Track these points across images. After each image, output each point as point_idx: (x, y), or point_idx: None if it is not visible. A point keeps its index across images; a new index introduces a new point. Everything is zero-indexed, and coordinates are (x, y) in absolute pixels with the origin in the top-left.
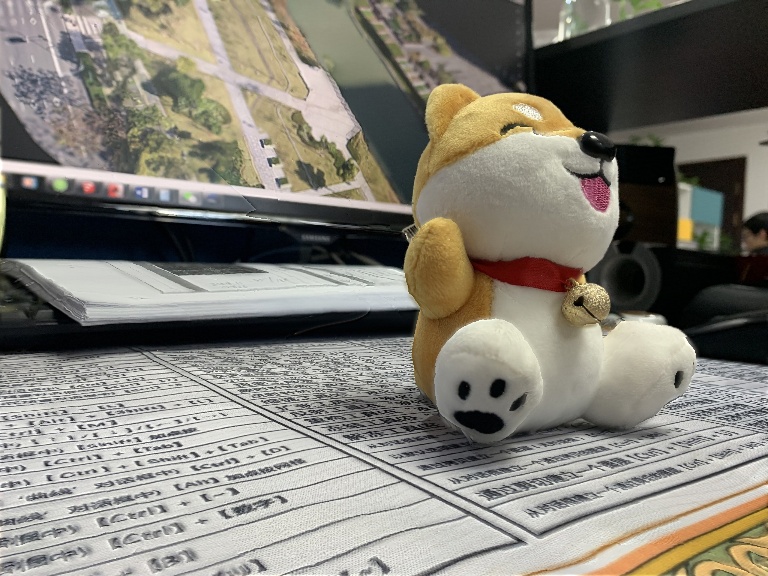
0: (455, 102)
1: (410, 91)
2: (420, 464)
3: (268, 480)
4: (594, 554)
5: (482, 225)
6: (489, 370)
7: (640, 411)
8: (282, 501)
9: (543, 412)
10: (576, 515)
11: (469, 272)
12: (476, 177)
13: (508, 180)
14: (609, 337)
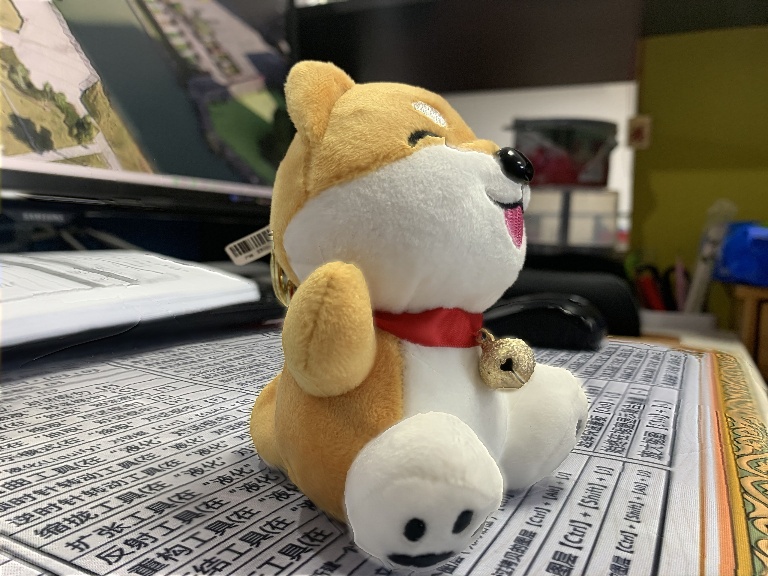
0: (331, 89)
1: (160, 37)
2: None
3: None
4: None
5: (391, 270)
6: (455, 502)
7: (544, 471)
8: None
9: None
10: None
11: (373, 334)
12: (386, 206)
13: (430, 213)
14: None
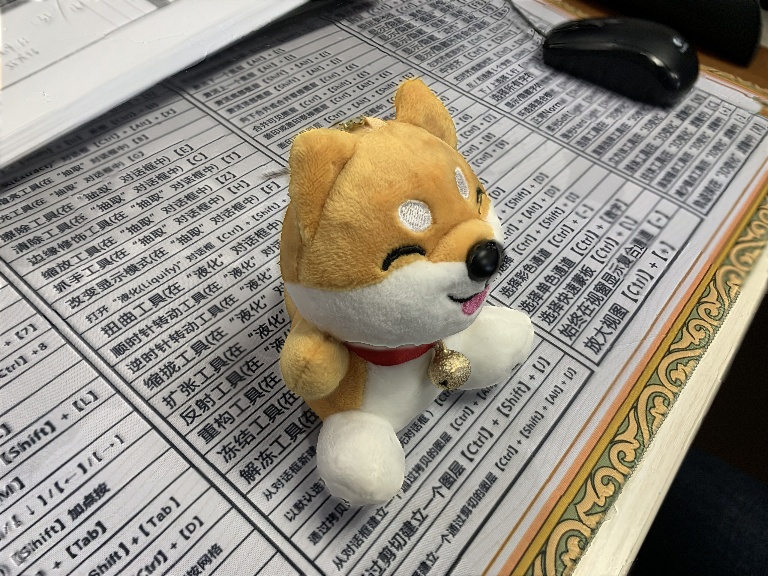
0: (326, 183)
1: None
2: (310, 531)
3: None
4: None
5: None
6: (365, 503)
7: None
8: None
9: None
10: None
11: None
12: (354, 319)
13: (388, 329)
14: (466, 333)
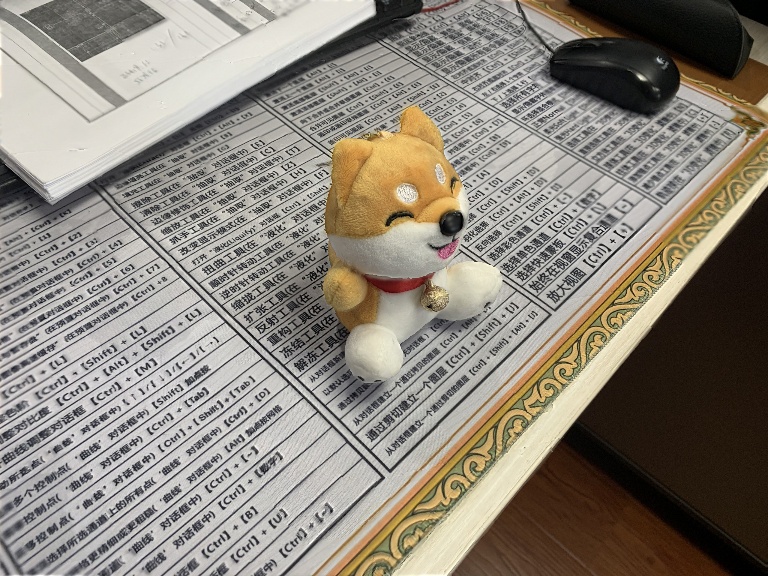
0: (354, 172)
1: None
2: (339, 402)
3: (268, 433)
4: (410, 480)
5: None
6: (374, 379)
7: None
8: (280, 458)
9: (406, 339)
10: (408, 450)
11: (364, 291)
12: (369, 256)
13: (390, 263)
14: (452, 278)
